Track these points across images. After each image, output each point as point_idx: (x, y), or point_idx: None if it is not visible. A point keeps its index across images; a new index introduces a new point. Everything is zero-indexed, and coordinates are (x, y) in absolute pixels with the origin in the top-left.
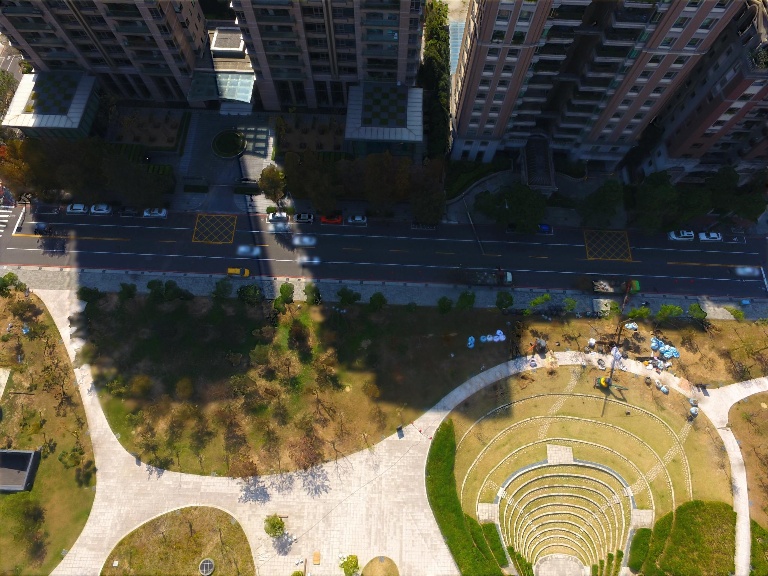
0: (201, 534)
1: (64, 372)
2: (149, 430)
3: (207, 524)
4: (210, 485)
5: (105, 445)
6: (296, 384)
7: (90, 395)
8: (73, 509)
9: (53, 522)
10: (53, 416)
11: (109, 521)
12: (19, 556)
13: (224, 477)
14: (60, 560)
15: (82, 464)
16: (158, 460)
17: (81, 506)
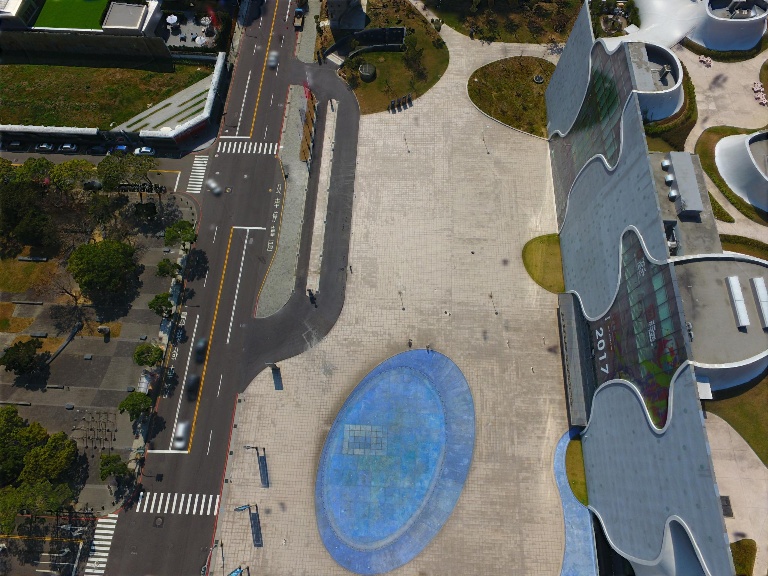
0: (529, 66)
1: (403, 0)
2: (474, 24)
3: (531, 63)
4: (526, 47)
5: (446, 32)
6: (568, 4)
7: (426, 11)
8: (437, 58)
9: (427, 63)
10: (406, 18)
11: (464, 63)
12: (410, 78)
13: (534, 44)
14: (438, 80)
15: (435, 39)
16: (486, 37)
17: (442, 57)
